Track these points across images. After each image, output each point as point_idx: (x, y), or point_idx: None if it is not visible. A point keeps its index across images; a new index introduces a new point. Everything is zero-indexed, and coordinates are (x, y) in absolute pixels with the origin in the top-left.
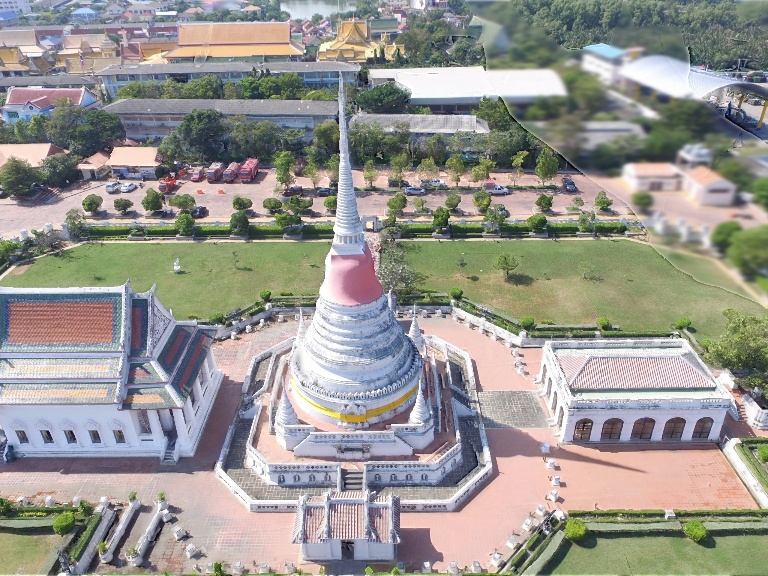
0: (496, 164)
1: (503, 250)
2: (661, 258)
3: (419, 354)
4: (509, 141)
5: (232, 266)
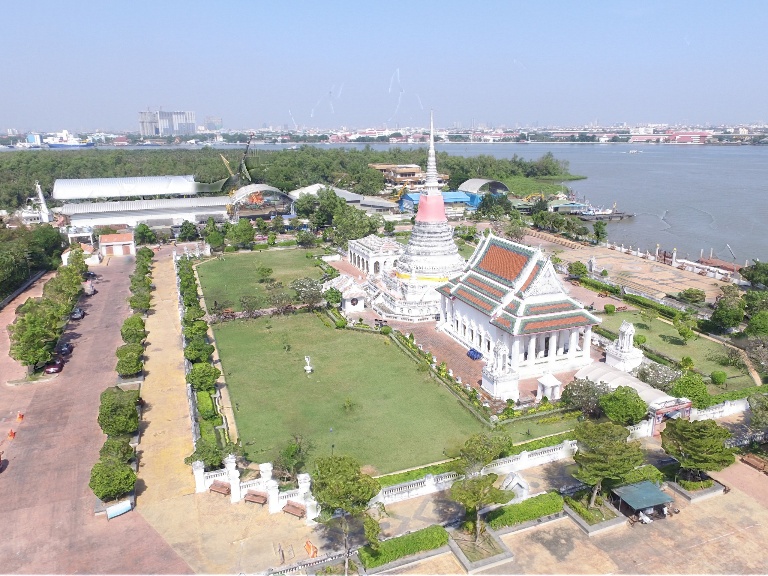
0: (3, 293)
1: (220, 286)
2: (225, 261)
3: None
4: (10, 262)
5: (284, 354)
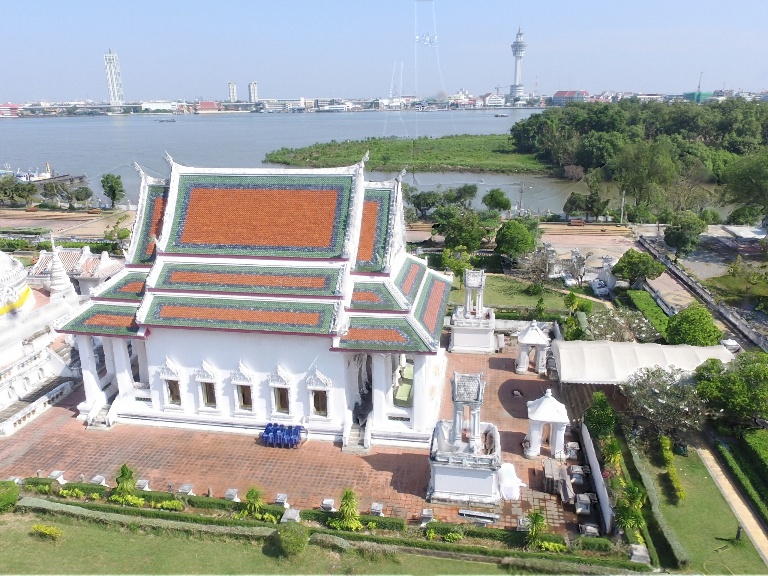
0: None
1: None
2: None
3: None
4: None
5: None
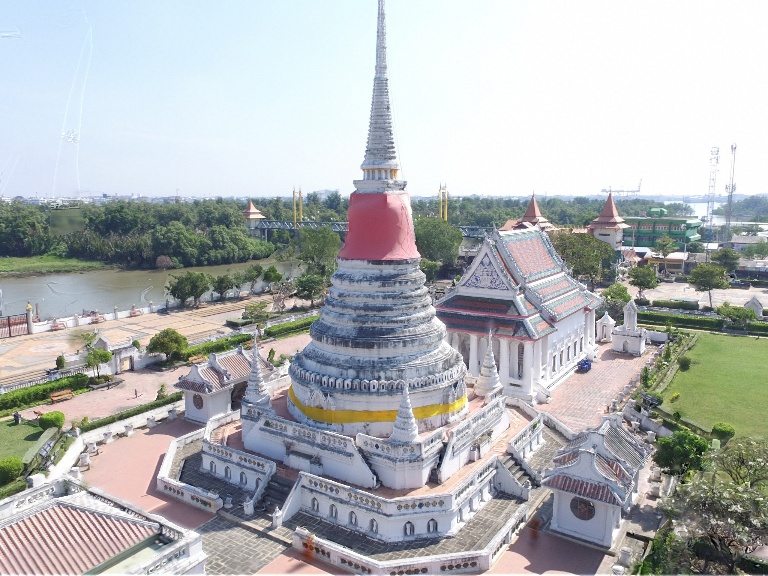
0: None
1: None
2: None
3: (332, 389)
4: None
5: None
